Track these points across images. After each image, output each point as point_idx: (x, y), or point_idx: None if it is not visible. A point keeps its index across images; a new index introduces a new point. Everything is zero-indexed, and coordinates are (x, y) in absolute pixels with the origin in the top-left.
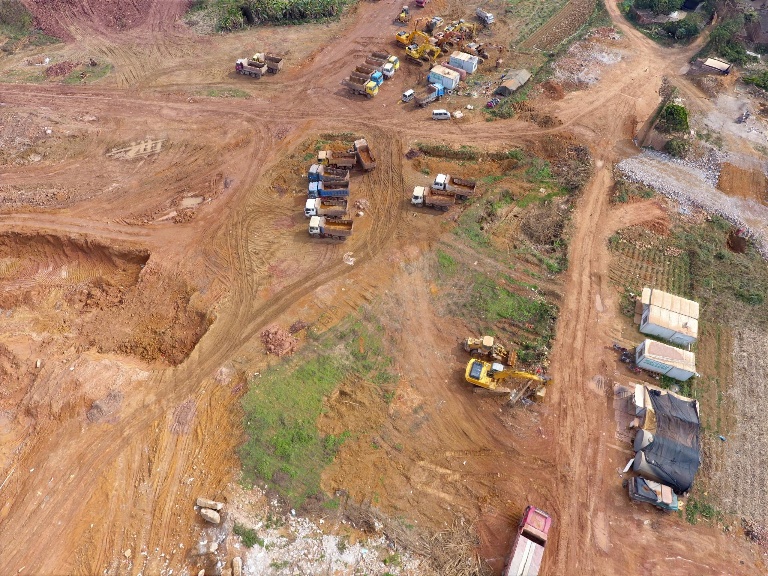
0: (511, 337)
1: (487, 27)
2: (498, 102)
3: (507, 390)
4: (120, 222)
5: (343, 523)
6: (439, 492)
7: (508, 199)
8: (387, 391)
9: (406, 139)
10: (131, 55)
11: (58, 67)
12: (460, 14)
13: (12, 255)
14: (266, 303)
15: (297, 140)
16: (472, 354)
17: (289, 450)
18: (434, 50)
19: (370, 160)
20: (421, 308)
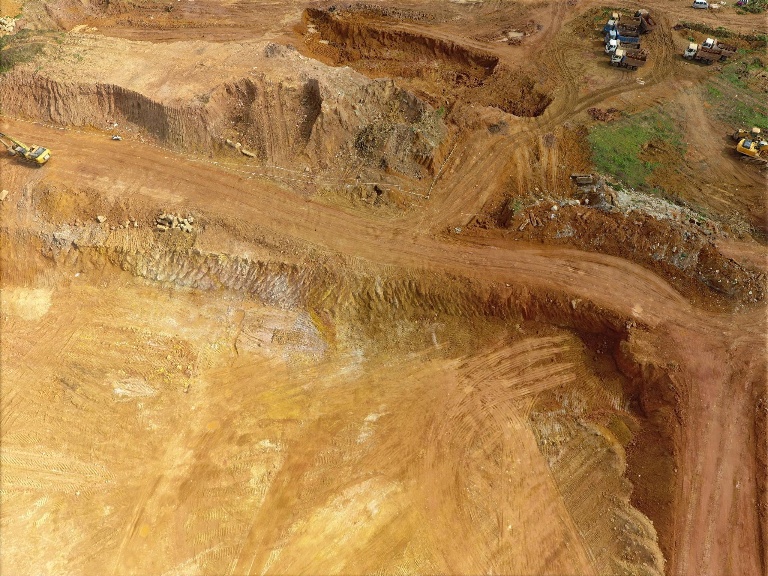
0: (765, 138)
1: None
2: (746, 3)
3: (766, 160)
4: (472, 38)
5: (663, 199)
6: (721, 199)
7: (757, 65)
8: (681, 149)
9: (672, 18)
10: None
11: None
12: None
13: (399, 49)
14: (587, 96)
15: (585, 8)
16: (739, 141)
17: (624, 163)
18: None
19: None
20: (699, 113)
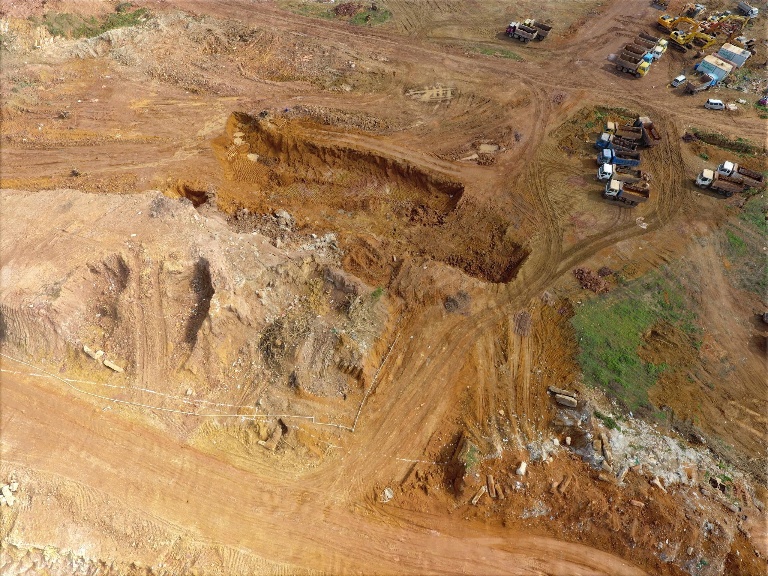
0: None
1: (751, 22)
2: None
3: None
4: (433, 155)
5: (673, 431)
6: (750, 428)
7: None
8: (696, 339)
9: (680, 123)
10: (404, 4)
11: (345, 7)
12: (718, 4)
13: (344, 168)
14: (573, 247)
15: (574, 107)
16: None
17: (619, 367)
18: (708, 39)
19: (653, 137)
20: (717, 278)
